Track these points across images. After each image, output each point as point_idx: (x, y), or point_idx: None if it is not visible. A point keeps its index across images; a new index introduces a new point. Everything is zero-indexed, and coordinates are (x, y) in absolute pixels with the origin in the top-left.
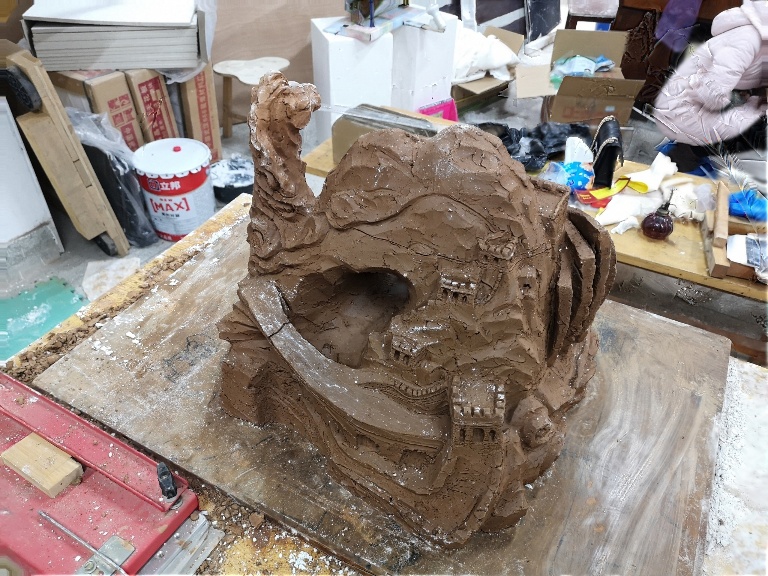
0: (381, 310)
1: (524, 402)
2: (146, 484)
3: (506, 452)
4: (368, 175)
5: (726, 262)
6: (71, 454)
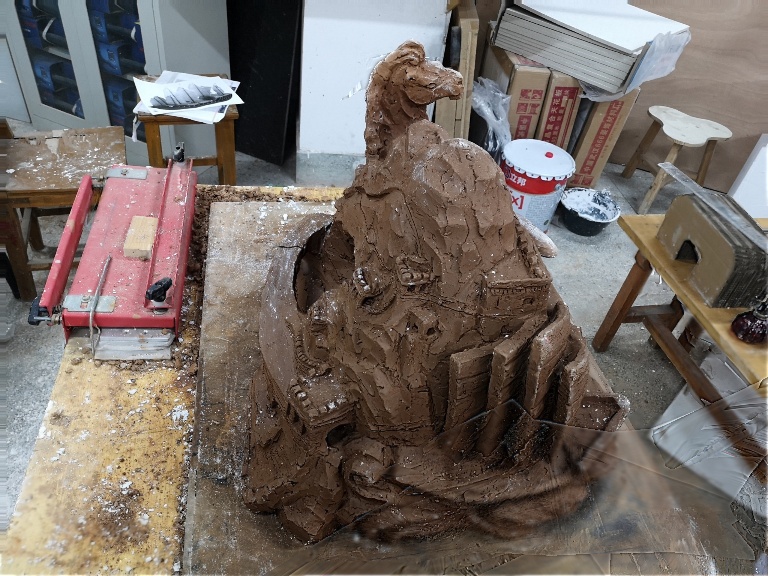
0: None
1: (367, 441)
2: None
3: (317, 463)
4: None
5: None
6: None
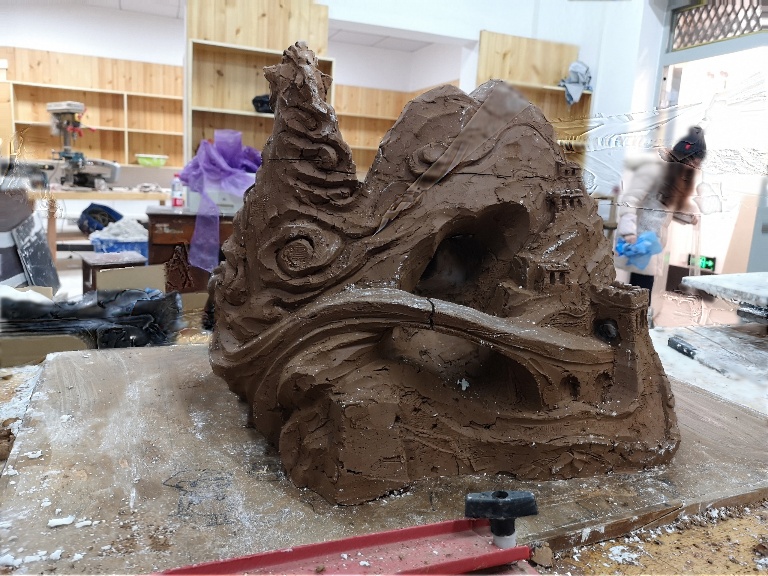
0: None
1: None
2: (461, 553)
3: None
4: (450, 122)
5: None
6: None
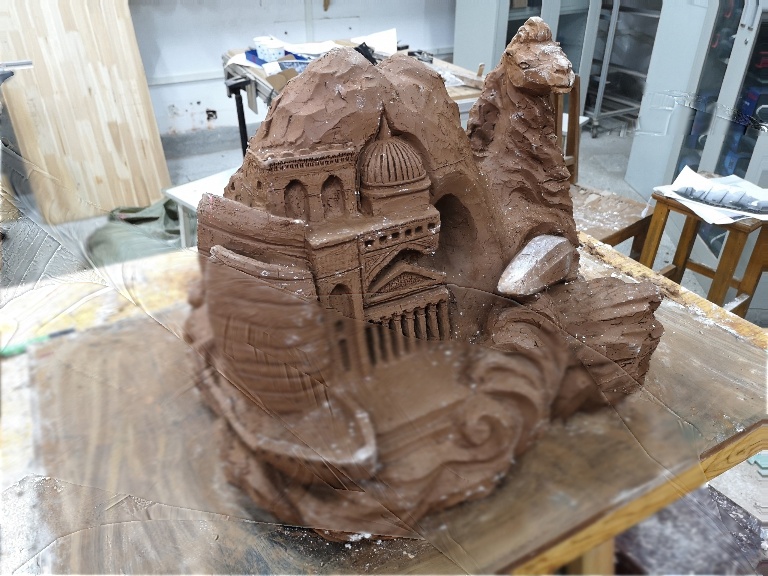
0: None
1: None
2: None
3: None
4: None
5: None
6: None
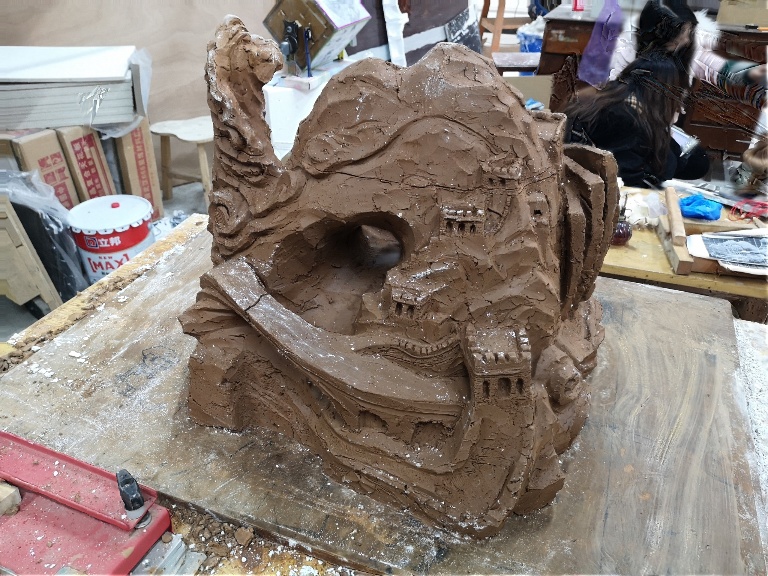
0: (368, 282)
1: (546, 352)
2: (103, 501)
3: (535, 409)
4: (348, 109)
5: (689, 258)
6: (4, 477)
